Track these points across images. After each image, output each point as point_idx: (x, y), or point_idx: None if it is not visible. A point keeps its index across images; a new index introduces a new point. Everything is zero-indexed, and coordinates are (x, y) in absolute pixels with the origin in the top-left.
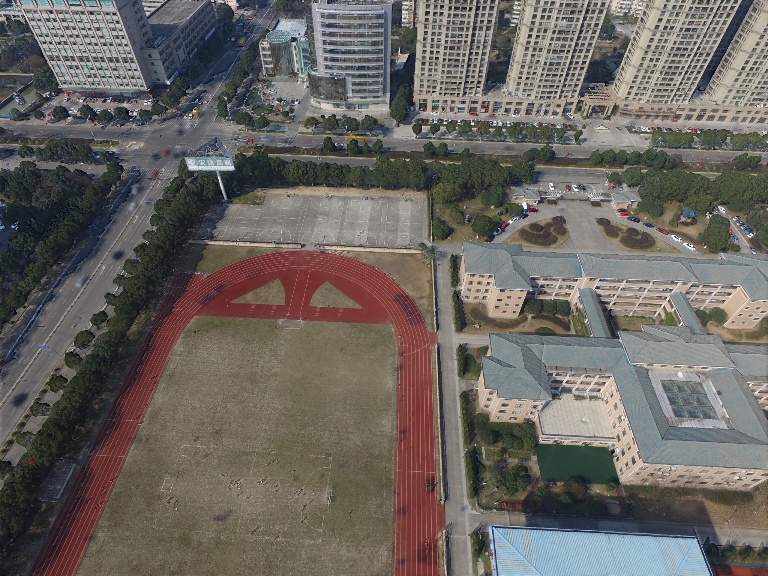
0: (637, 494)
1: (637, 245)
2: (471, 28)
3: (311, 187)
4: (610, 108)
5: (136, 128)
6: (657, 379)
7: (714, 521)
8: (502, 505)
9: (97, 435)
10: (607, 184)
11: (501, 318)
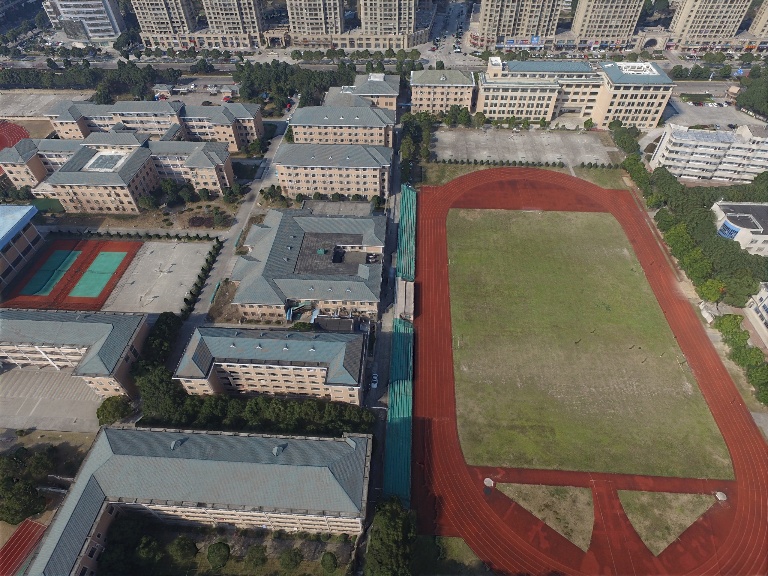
0: (70, 216)
1: None
2: None
3: (23, 89)
4: (282, 39)
5: None
6: None
7: (102, 225)
8: None
9: None
10: (235, 84)
11: None
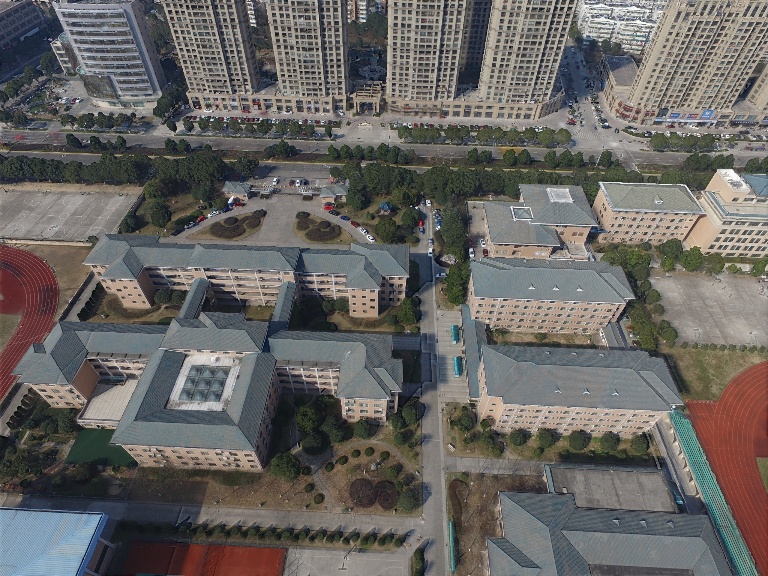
0: (147, 476)
1: (318, 237)
2: (215, 26)
3: (36, 183)
4: (377, 105)
5: None
6: (190, 364)
7: (206, 501)
8: (5, 487)
9: None
10: None
11: (134, 308)
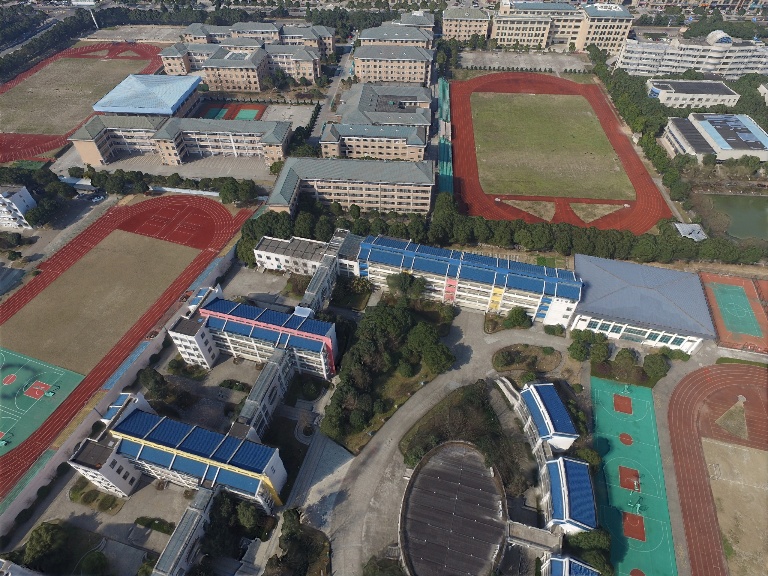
0: (213, 92)
1: None
2: None
3: (146, 25)
4: None
5: (65, 7)
6: None
7: (237, 97)
8: None
9: (7, 81)
10: None
11: None
